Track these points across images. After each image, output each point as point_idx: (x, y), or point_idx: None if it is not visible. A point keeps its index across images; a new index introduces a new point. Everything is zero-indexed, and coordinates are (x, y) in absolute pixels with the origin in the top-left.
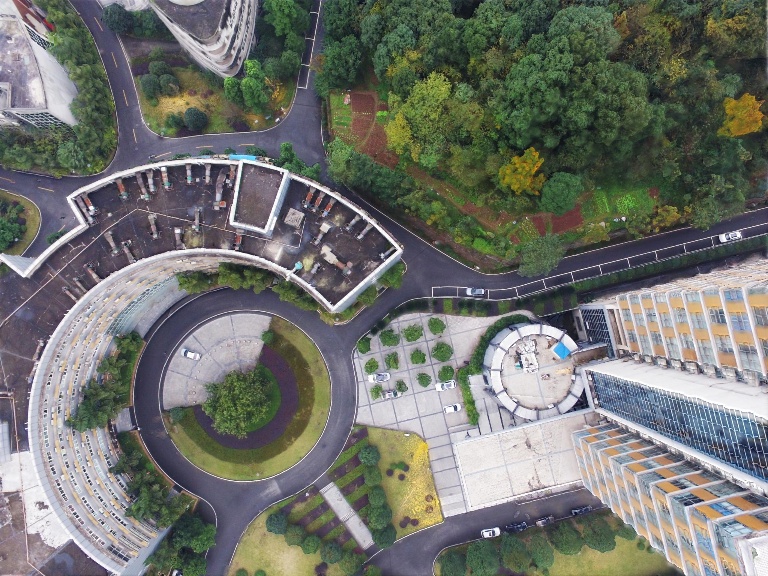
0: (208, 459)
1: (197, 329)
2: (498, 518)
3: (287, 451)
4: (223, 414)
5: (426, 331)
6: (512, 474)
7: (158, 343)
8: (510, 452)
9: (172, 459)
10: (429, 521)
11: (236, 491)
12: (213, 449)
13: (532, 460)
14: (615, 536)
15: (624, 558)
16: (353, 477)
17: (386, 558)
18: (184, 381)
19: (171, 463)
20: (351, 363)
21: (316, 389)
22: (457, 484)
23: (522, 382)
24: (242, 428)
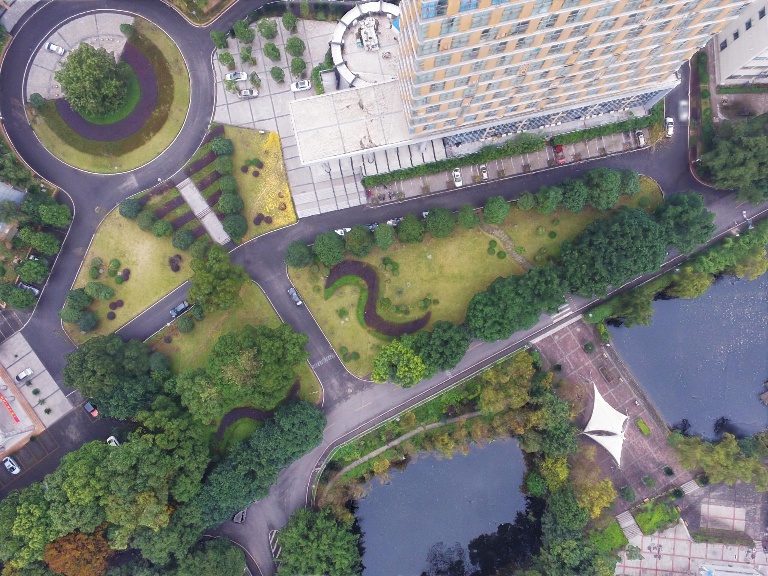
0: (68, 151)
1: (62, 26)
2: (351, 220)
3: (145, 146)
4: (69, 75)
5: (284, 35)
6: (344, 133)
7: (24, 39)
8: (343, 112)
9: (34, 151)
10: (283, 221)
11: (95, 183)
12: (72, 140)
13: (364, 120)
14: (466, 241)
15: (475, 264)
16: (208, 172)
17: (240, 256)
18: (48, 75)
19: (33, 155)
20: (210, 64)
21: (175, 87)
22: (310, 182)
23: (363, 60)
24: (90, 96)
